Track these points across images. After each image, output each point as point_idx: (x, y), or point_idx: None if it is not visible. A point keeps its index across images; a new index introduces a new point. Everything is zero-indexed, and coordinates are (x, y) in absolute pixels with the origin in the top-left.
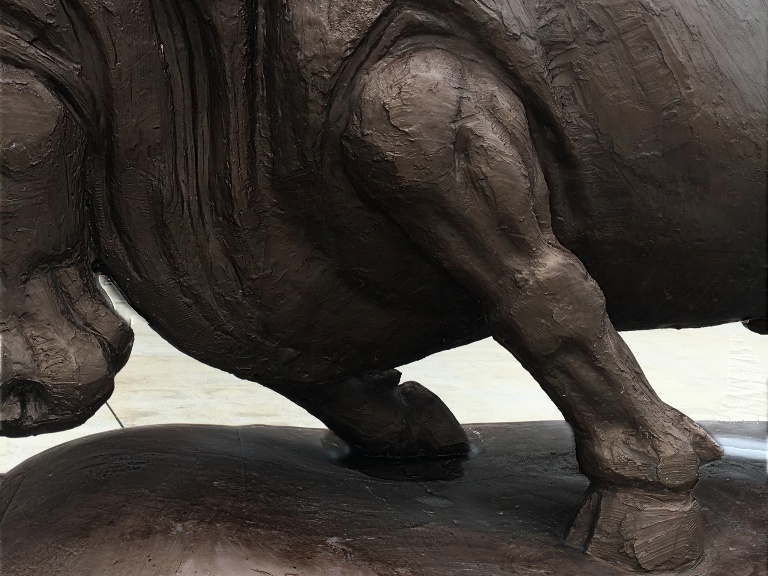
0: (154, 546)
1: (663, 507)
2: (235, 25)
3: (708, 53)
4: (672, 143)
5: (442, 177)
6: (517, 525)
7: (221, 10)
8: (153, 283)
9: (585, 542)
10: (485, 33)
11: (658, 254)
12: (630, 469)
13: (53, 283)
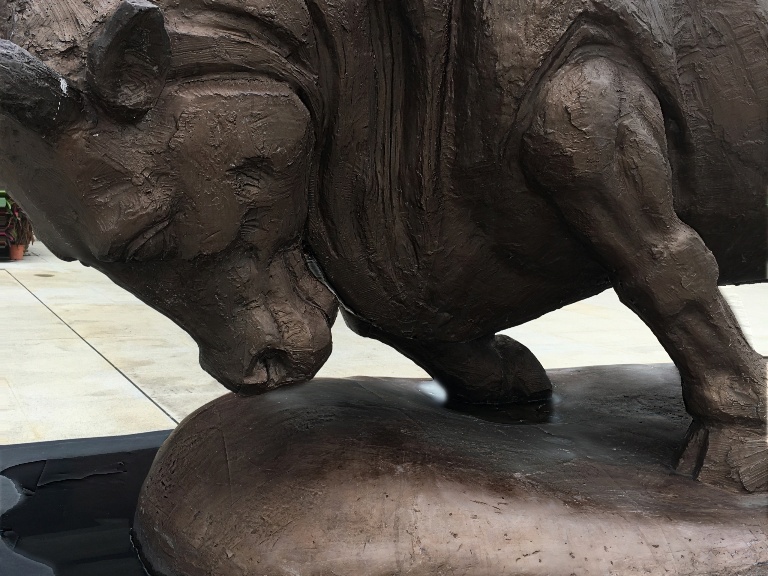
0: (387, 485)
1: (761, 440)
2: (440, 38)
3: None
4: None
5: (605, 168)
6: (633, 459)
7: (431, 26)
8: (347, 260)
9: (693, 471)
10: (637, 42)
11: (746, 225)
12: (735, 409)
13: (285, 264)
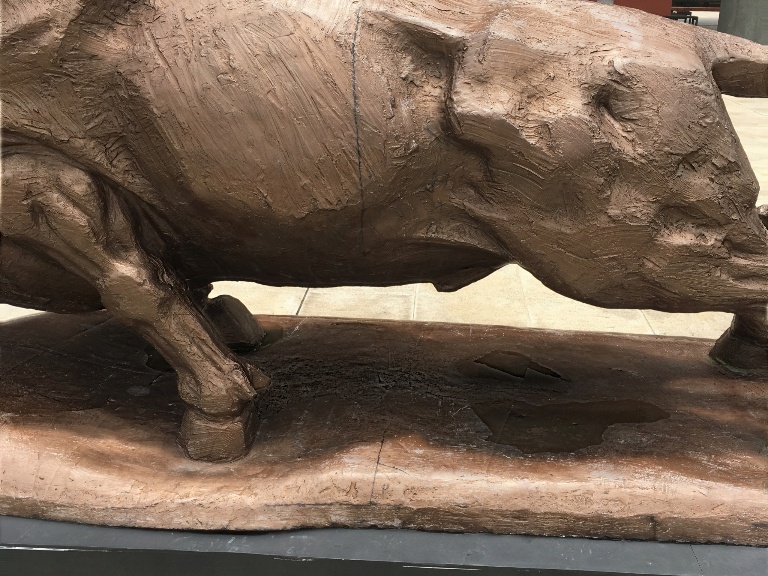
0: None
1: (207, 424)
2: None
3: (196, 141)
4: (189, 199)
5: (27, 230)
6: (163, 415)
7: None
8: None
9: None
10: (43, 142)
11: (242, 256)
12: (189, 399)
13: None
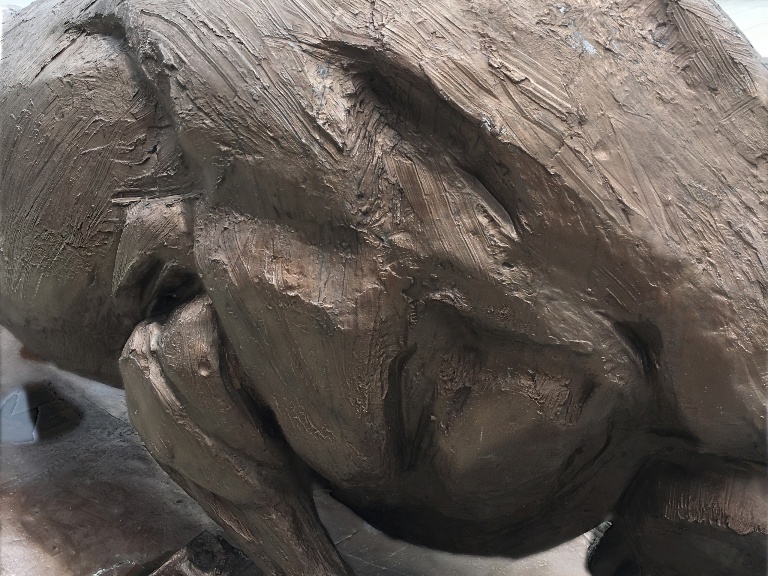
0: None
1: None
2: None
3: None
4: None
5: None
6: None
7: None
8: None
9: None
10: None
11: None
12: None
13: None
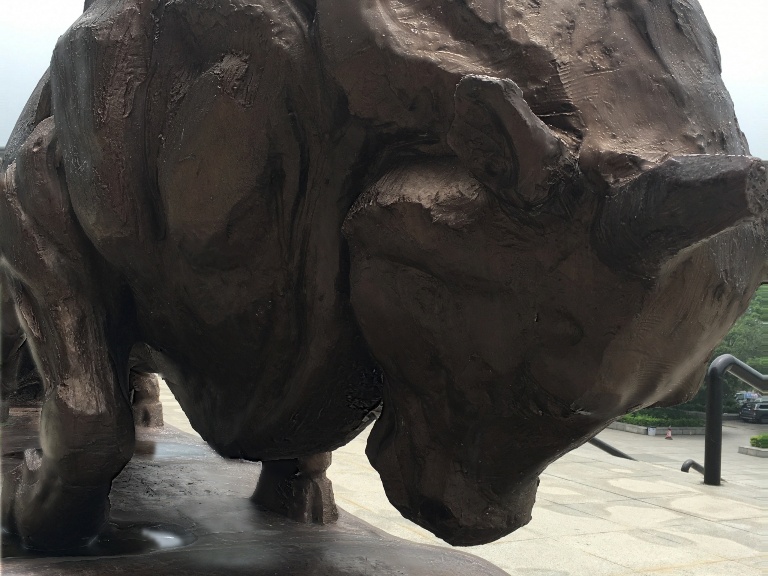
0: None
1: None
2: None
3: None
4: None
5: None
6: None
7: None
8: None
9: (313, 519)
10: None
11: None
12: None
13: None
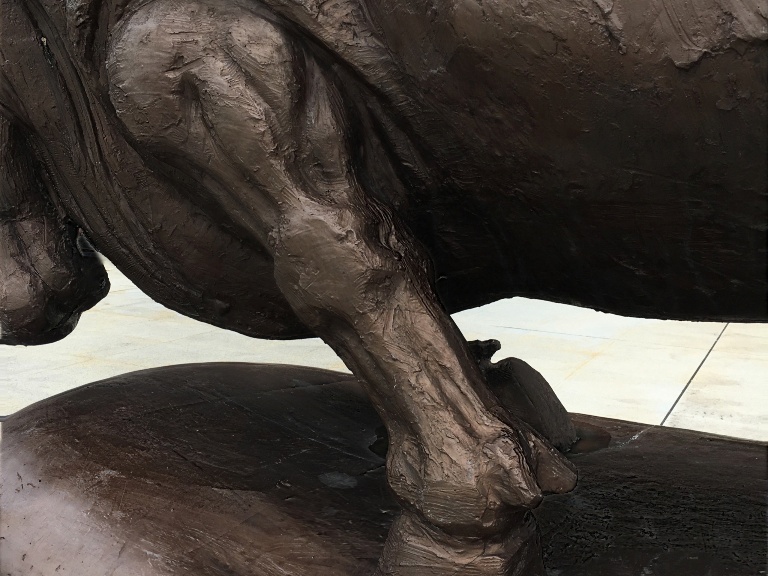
0: (3, 439)
1: (430, 547)
2: (58, 12)
3: None
4: (446, 52)
5: (170, 129)
6: (365, 526)
7: (44, 2)
8: (99, 235)
9: None
10: None
11: (545, 208)
12: (402, 487)
13: (10, 233)
